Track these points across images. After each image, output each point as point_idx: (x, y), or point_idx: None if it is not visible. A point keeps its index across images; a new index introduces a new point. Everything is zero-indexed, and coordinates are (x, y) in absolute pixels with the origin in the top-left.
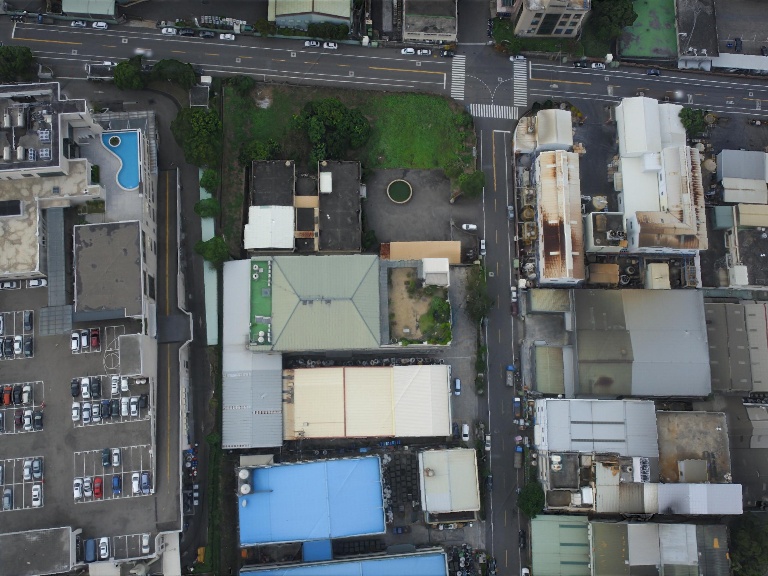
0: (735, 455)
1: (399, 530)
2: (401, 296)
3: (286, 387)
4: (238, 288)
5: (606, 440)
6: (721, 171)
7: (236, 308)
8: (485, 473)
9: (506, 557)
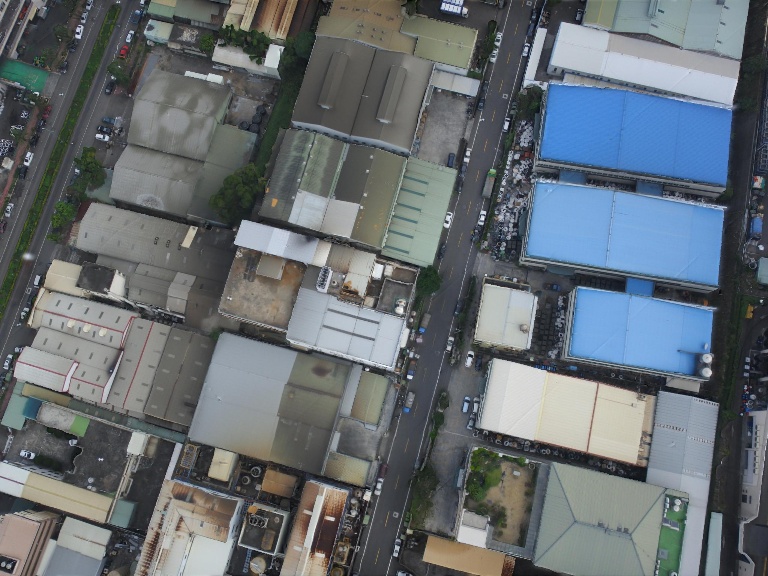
0: (214, 274)
1: (555, 288)
2: (513, 513)
3: (646, 448)
4: (684, 569)
5: (345, 315)
6: (100, 569)
7: (689, 547)
8: (463, 317)
9: (460, 241)
